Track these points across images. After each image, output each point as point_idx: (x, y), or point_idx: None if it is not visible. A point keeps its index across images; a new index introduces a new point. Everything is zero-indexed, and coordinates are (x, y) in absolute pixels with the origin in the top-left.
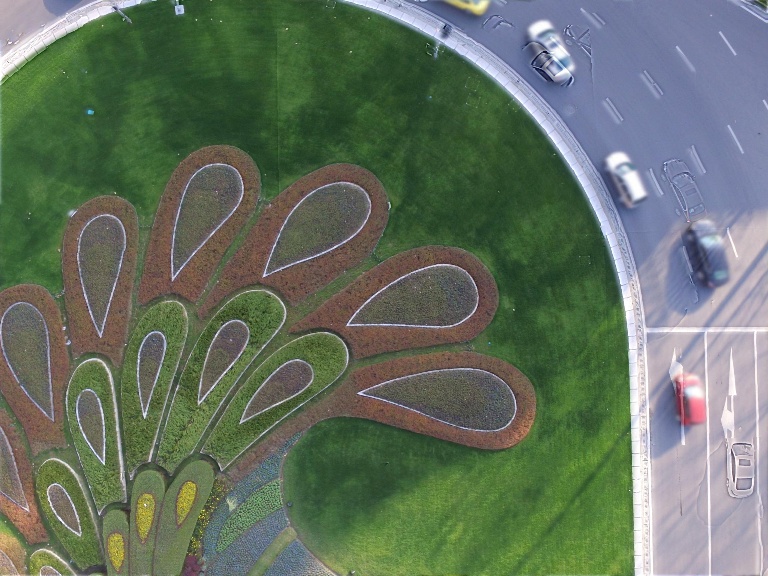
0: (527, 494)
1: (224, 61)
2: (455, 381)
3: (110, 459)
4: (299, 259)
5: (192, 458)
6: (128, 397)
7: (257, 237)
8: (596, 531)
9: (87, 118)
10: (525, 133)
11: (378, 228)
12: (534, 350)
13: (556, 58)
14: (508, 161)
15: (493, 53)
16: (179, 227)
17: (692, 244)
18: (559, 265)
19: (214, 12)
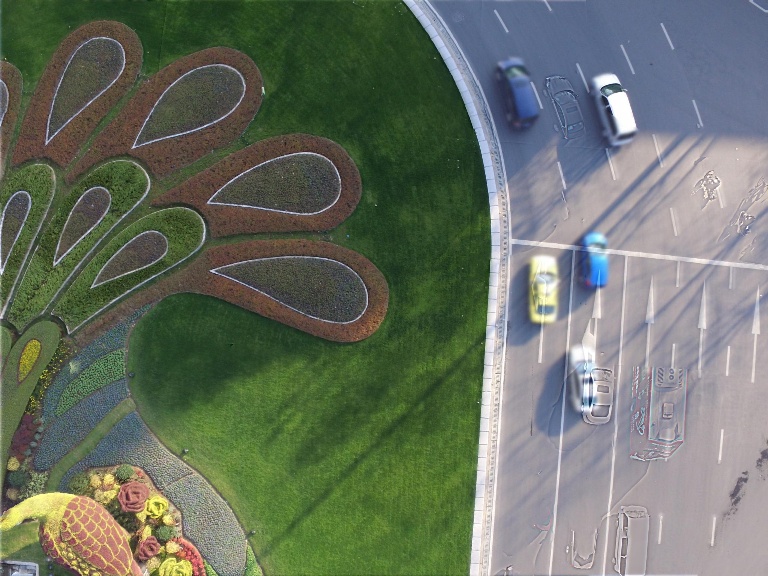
0: (371, 392)
1: None
2: (308, 268)
3: None
4: (169, 134)
5: (43, 319)
6: None
7: (131, 109)
8: (439, 439)
9: None
10: (408, 35)
11: (249, 111)
12: (392, 247)
13: None
14: (387, 60)
15: None
16: (59, 94)
17: (567, 160)
18: (426, 166)
19: None
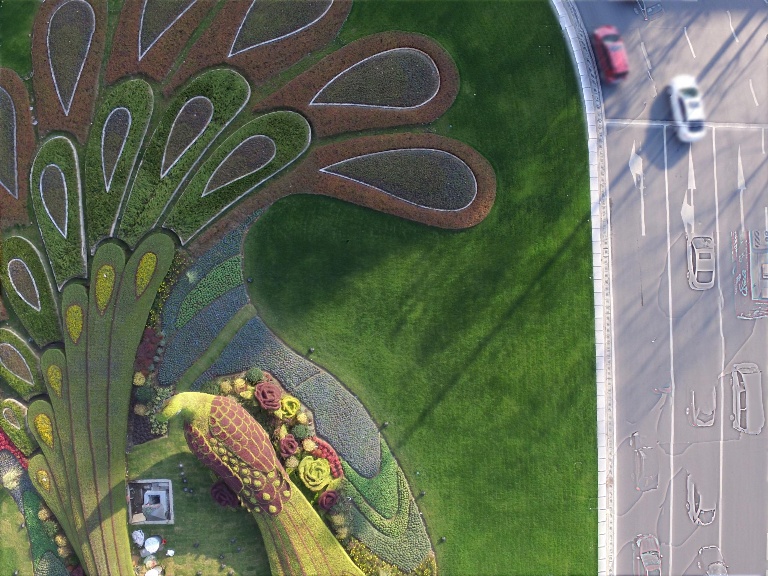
0: (488, 276)
1: None
2: (416, 159)
3: (72, 233)
4: (264, 40)
5: None
6: (92, 171)
7: (223, 18)
8: (557, 316)
9: None
10: None
11: (342, 12)
12: (495, 134)
13: None
14: None
15: None
16: (147, 9)
17: (650, 41)
18: (519, 53)
19: None
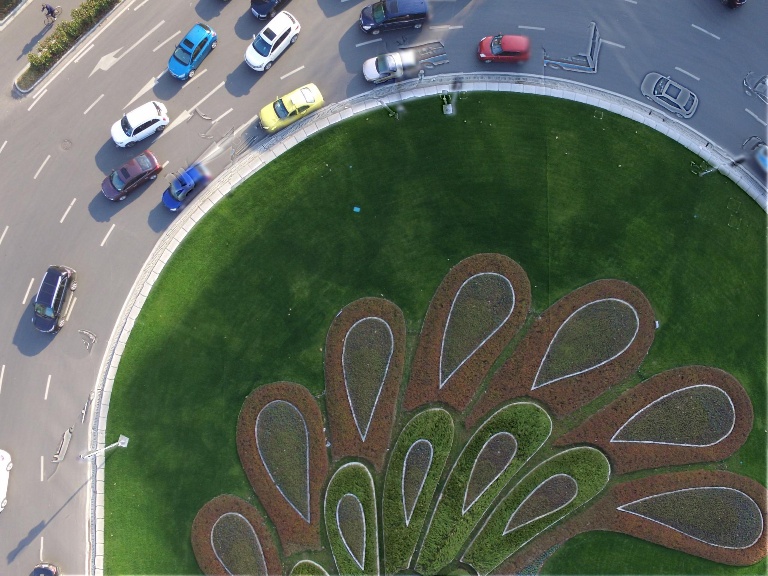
0: None
1: (494, 167)
2: (710, 500)
3: (369, 565)
4: (568, 374)
5: (450, 566)
6: (392, 504)
7: (528, 350)
8: None
9: (352, 215)
10: None
11: (645, 346)
12: None
13: None
14: (767, 285)
15: (752, 174)
16: (449, 335)
17: None
18: None
19: (482, 114)
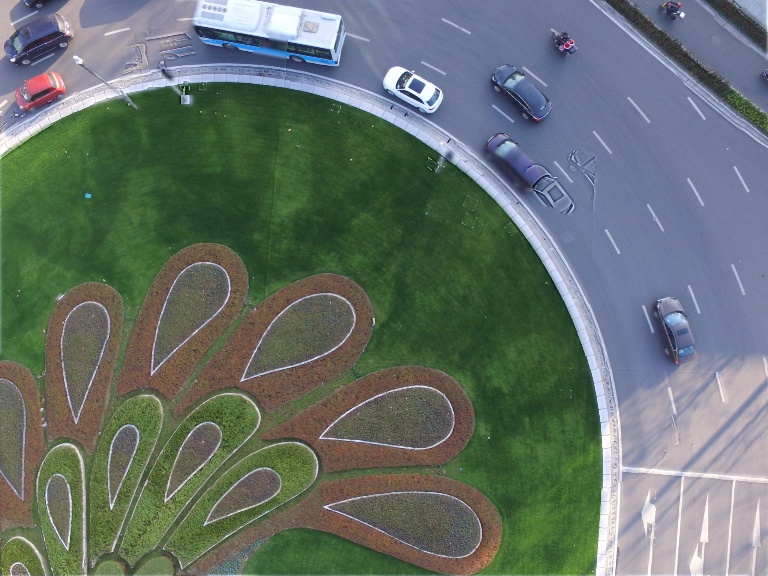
0: None
1: (224, 157)
2: (422, 505)
3: (74, 545)
4: (278, 367)
5: (154, 553)
6: (97, 487)
7: (239, 341)
8: None
9: (84, 201)
10: (519, 259)
11: (360, 343)
12: (505, 480)
13: (558, 183)
14: (498, 286)
15: (495, 172)
16: (163, 322)
17: (678, 386)
18: (539, 397)
19: (219, 105)
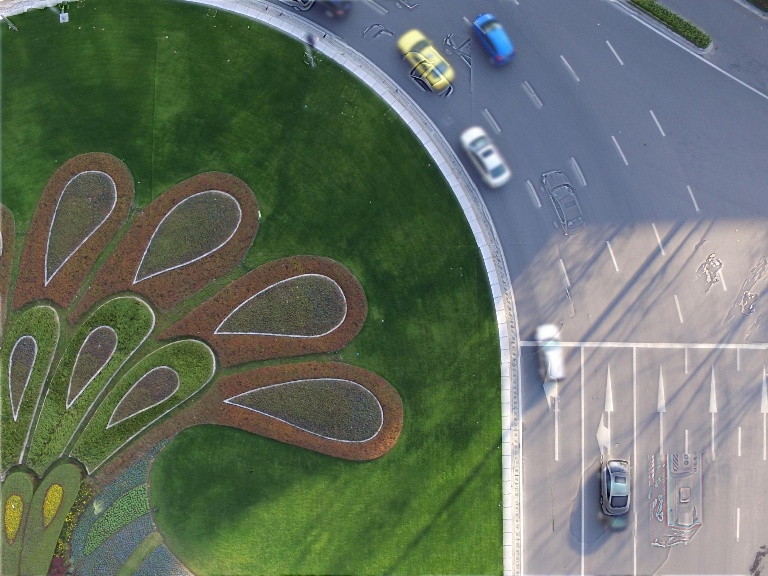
0: (393, 506)
1: (104, 69)
2: (321, 391)
3: None
4: (169, 267)
5: (62, 461)
6: None
7: (128, 244)
8: (464, 545)
9: None
10: (400, 143)
11: (247, 237)
12: (403, 362)
13: (435, 68)
14: (381, 171)
15: (372, 62)
16: (53, 233)
17: (569, 257)
18: (430, 277)
19: (97, 20)
